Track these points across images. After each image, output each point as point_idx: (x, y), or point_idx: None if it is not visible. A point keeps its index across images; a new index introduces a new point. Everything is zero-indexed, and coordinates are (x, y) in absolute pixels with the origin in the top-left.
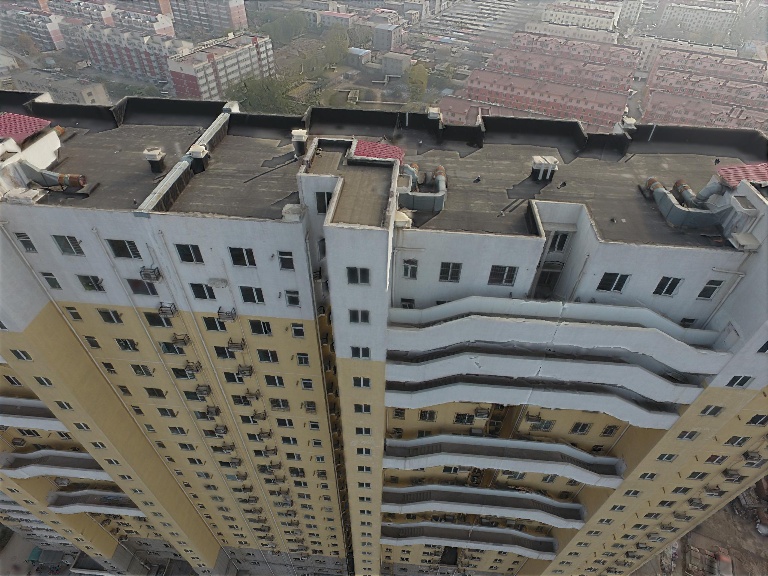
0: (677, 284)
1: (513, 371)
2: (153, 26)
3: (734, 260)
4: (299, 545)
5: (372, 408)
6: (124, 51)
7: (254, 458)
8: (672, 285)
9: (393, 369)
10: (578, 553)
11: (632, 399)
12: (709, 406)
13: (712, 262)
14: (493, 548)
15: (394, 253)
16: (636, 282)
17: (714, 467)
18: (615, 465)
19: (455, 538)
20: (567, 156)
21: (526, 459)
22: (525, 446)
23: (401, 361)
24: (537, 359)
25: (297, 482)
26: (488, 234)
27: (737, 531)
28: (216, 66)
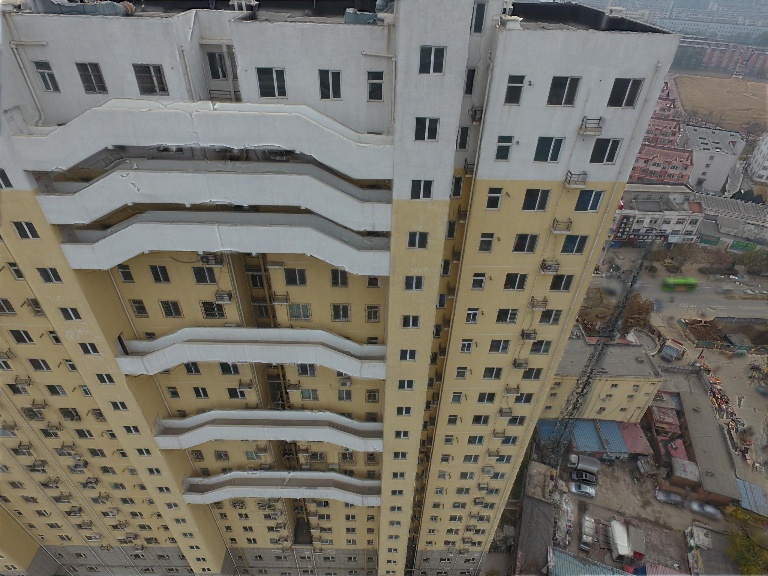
0: (340, 81)
1: (178, 194)
2: None
3: (378, 38)
4: (127, 533)
5: (59, 273)
6: None
7: (12, 397)
8: (336, 84)
9: (48, 203)
10: (402, 491)
11: (340, 238)
12: (413, 233)
13: (357, 42)
14: (309, 494)
15: (14, 50)
16: (294, 79)
17: (502, 358)
18: (385, 354)
19: (264, 485)
20: (295, 15)
21: (272, 343)
22: (281, 336)
23: (56, 193)
24: (196, 173)
25: (80, 432)
26: (106, 16)
27: (636, 500)
28: None
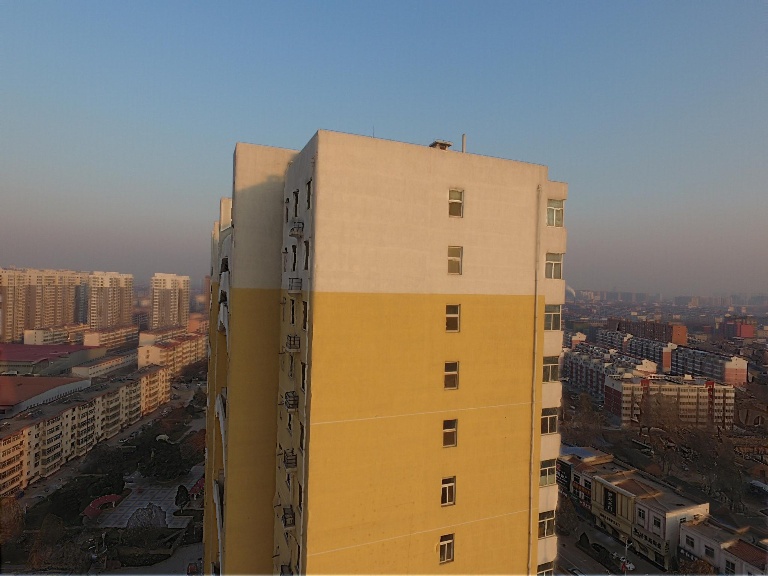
0: None
1: None
2: (636, 367)
3: None
4: None
5: None
6: (590, 372)
7: None
8: None
9: None
10: None
11: None
12: None
13: None
14: None
15: None
16: None
17: None
18: None
19: None
20: None
21: None
22: None
23: None
24: None
25: None
26: None
27: None
28: (649, 391)
